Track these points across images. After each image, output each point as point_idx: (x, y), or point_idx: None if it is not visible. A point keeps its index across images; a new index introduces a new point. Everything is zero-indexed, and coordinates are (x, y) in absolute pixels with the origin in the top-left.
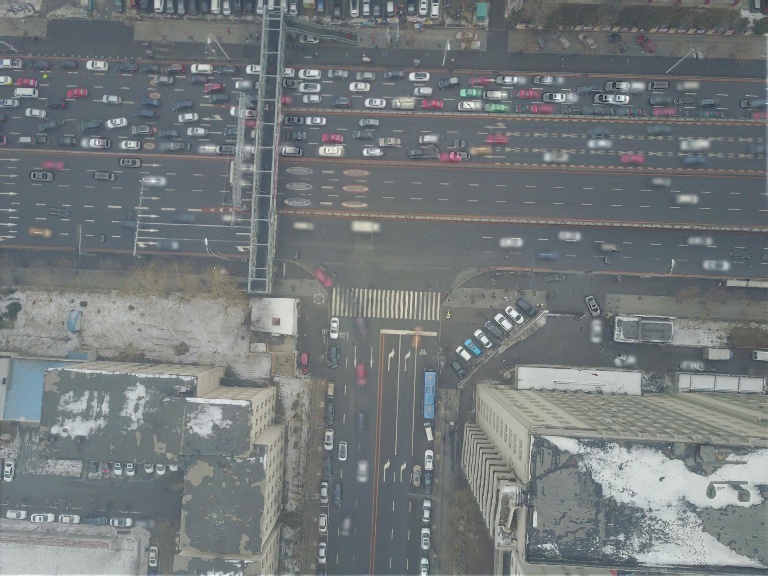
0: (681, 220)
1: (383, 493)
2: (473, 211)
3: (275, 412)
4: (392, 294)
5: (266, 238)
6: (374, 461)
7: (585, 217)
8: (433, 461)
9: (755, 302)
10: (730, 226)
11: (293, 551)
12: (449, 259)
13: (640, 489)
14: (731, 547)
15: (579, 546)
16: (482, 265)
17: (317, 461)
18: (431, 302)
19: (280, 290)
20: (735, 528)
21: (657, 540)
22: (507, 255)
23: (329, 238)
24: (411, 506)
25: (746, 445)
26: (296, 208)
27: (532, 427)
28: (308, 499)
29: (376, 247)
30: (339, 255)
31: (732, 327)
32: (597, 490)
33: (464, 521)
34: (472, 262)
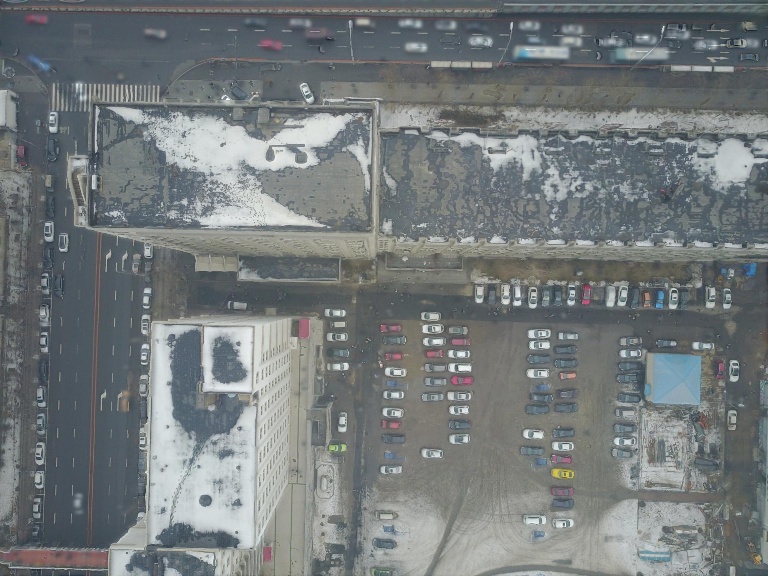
0: (389, 5)
1: (105, 283)
2: (189, 3)
3: None
4: (112, 89)
5: None
6: (96, 252)
7: (296, 5)
8: (153, 249)
9: (463, 85)
10: (434, 8)
11: (16, 343)
12: (168, 52)
13: (202, 155)
14: (289, 207)
15: (144, 212)
16: (200, 57)
17: (36, 251)
18: (151, 95)
19: None
20: (292, 189)
21: (219, 203)
22: (224, 47)
23: (47, 34)
24: (133, 295)
25: (300, 107)
26: (14, 5)
27: (95, 97)
28: (30, 291)
29: (95, 42)
30: (58, 51)
31: (441, 110)
32: (161, 157)
33: (184, 307)
34: (190, 54)
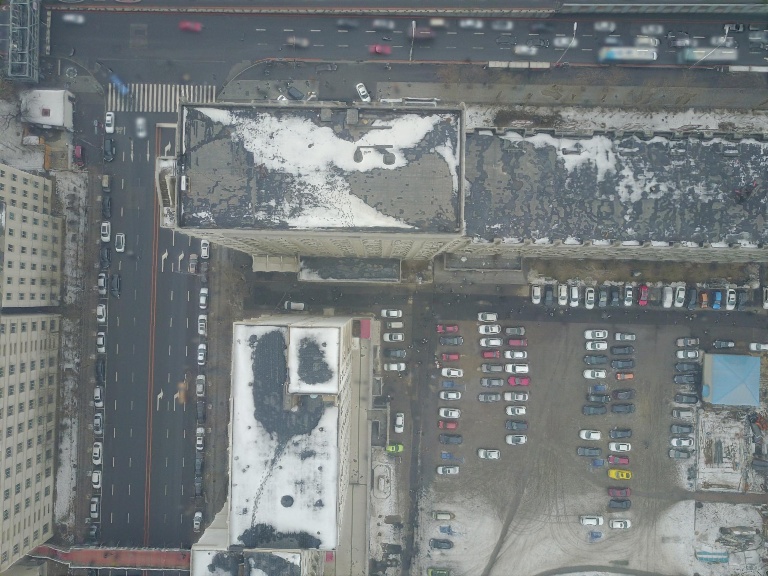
0: (446, 5)
1: (162, 283)
2: (245, 3)
3: (51, 206)
4: (168, 89)
5: (26, 21)
6: (152, 252)
7: (353, 5)
8: (209, 249)
9: (520, 85)
10: (492, 8)
11: (73, 343)
12: (224, 52)
13: (290, 156)
14: (377, 208)
15: (232, 213)
16: (256, 57)
17: None
18: (207, 95)
19: (55, 87)
20: (381, 190)
21: (307, 204)
22: (280, 47)
23: (103, 34)
24: (189, 295)
25: (389, 108)
26: (70, 5)
27: (183, 98)
28: (87, 291)
29: (151, 42)
30: (114, 51)
31: (498, 110)
32: (249, 158)
33: (241, 307)
34: (246, 54)
